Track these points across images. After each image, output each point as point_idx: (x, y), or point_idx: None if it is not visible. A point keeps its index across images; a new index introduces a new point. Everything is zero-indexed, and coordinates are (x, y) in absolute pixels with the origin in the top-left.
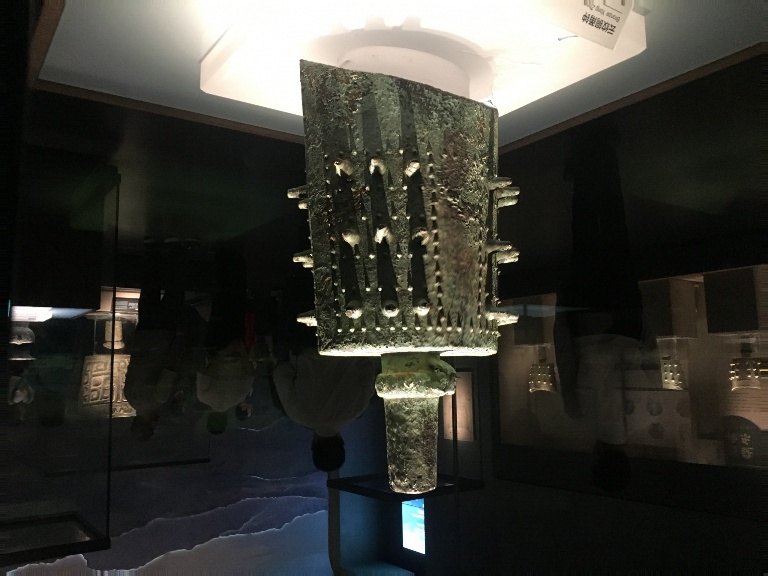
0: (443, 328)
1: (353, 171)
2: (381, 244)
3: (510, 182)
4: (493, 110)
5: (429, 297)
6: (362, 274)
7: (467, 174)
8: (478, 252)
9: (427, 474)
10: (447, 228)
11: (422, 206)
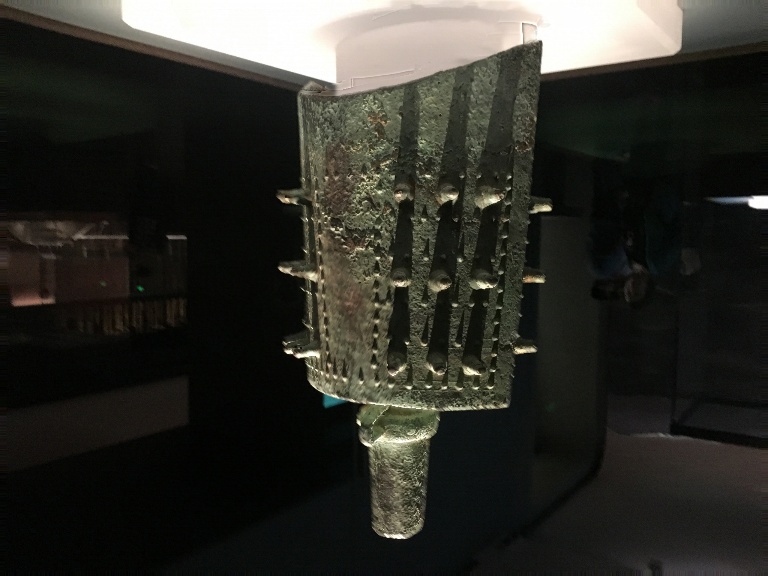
0: (330, 375)
1: None
2: None
3: (398, 194)
4: (417, 83)
5: (321, 339)
6: None
7: (352, 194)
8: (372, 288)
9: (383, 519)
10: (331, 263)
11: (314, 239)
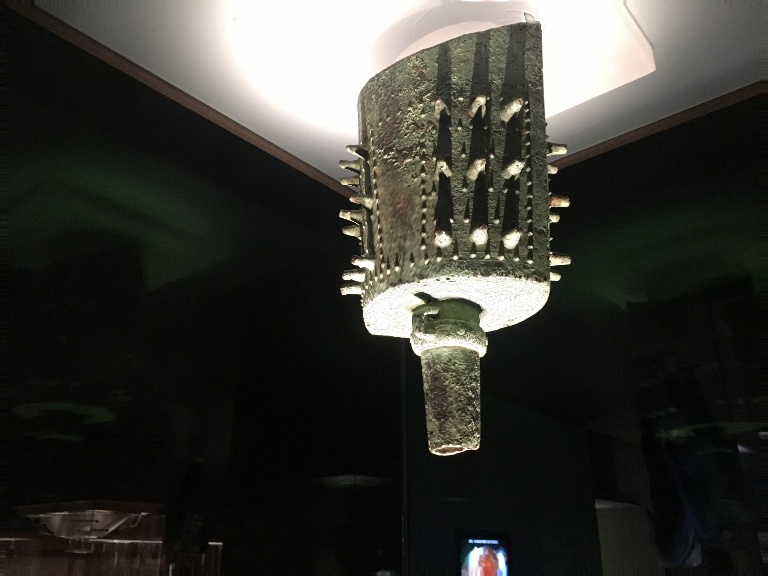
0: (384, 274)
1: None
2: None
3: (437, 101)
4: (448, 43)
5: (375, 251)
6: None
7: (401, 124)
8: (420, 186)
9: (438, 429)
10: (384, 183)
11: None
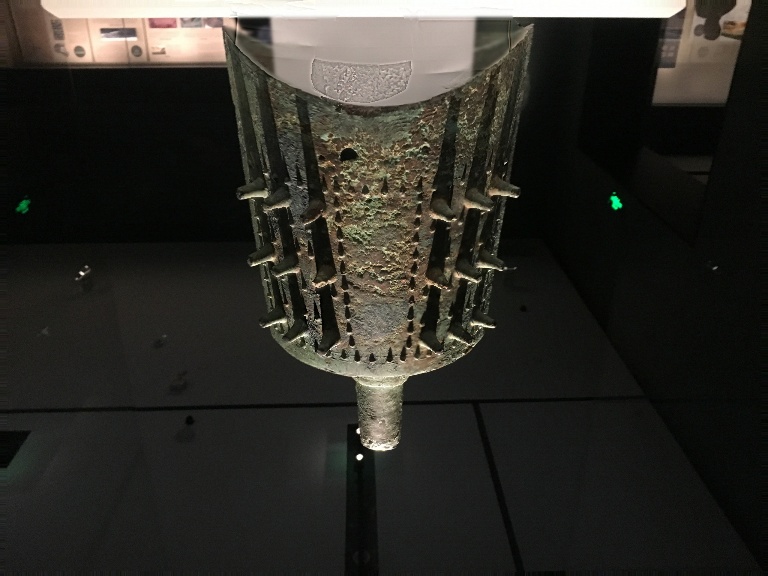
0: None
1: None
2: None
3: None
4: (313, 62)
5: None
6: None
7: None
8: None
9: None
10: None
11: None
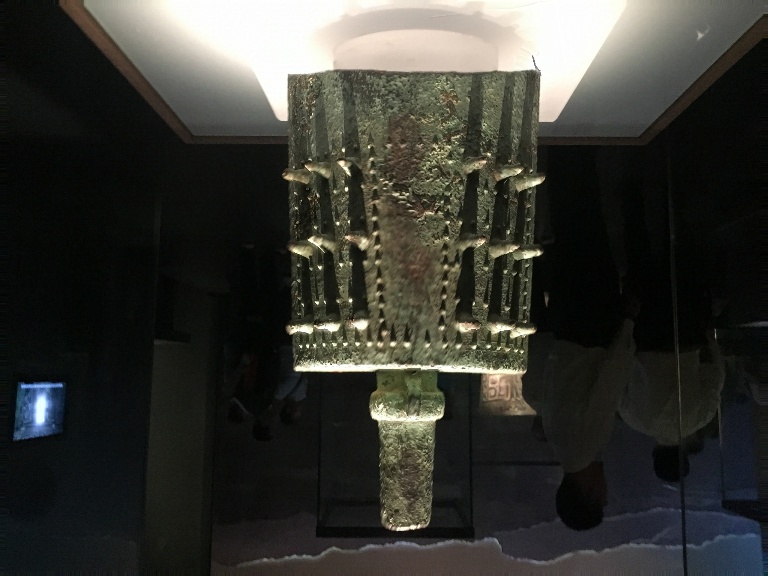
0: (385, 343)
1: (310, 179)
2: (326, 253)
3: (483, 161)
4: (481, 75)
5: (369, 308)
6: (314, 287)
7: (422, 161)
8: (441, 251)
9: (406, 508)
10: (391, 228)
11: (363, 207)
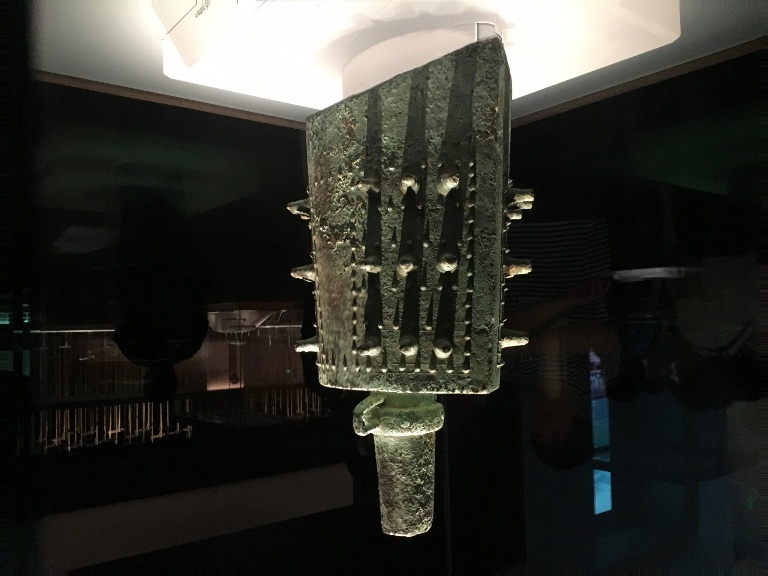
0: (325, 365)
1: None
2: None
3: (359, 185)
4: (379, 87)
5: (319, 334)
6: None
7: (333, 194)
8: (351, 278)
9: (387, 516)
10: None
11: None
